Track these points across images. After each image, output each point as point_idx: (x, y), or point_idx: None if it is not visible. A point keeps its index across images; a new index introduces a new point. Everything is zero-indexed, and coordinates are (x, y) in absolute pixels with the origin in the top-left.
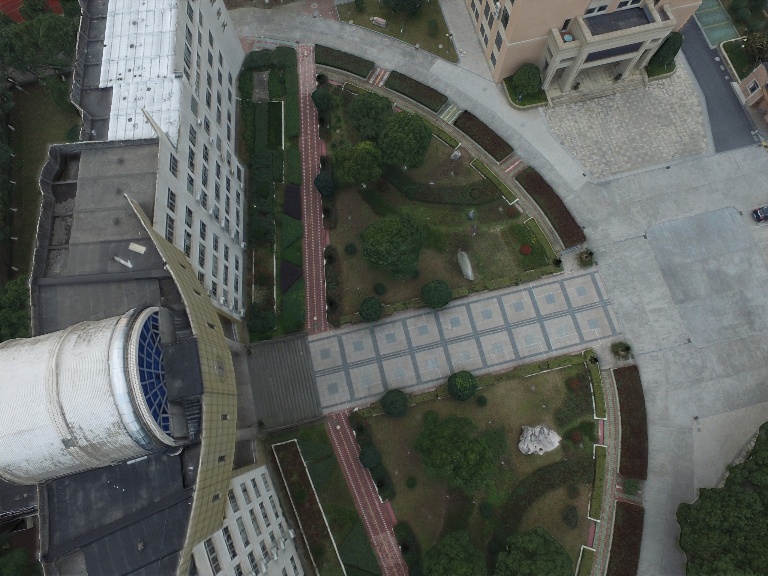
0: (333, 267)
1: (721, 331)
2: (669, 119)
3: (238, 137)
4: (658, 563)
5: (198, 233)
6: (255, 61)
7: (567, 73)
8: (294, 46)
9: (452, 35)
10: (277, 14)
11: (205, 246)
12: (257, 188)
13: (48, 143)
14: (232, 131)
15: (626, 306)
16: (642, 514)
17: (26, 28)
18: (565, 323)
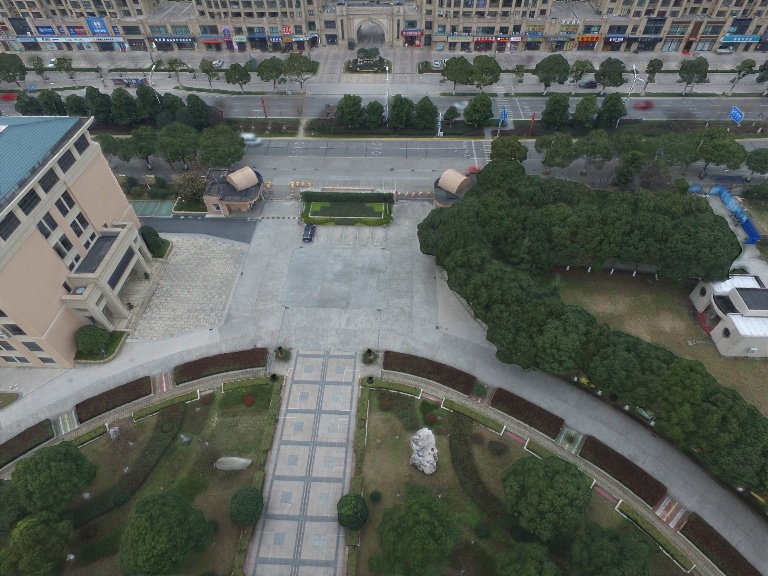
0: None
1: (379, 289)
2: (205, 259)
3: None
4: (542, 394)
5: None
6: None
7: (112, 306)
8: None
9: None
10: None
11: None
12: None
13: None
14: None
15: (336, 341)
16: (503, 390)
17: None
18: (330, 392)
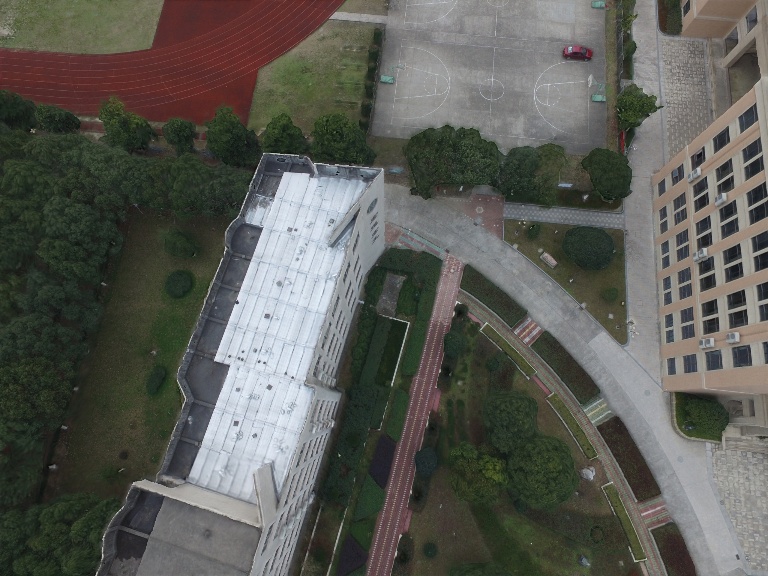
0: (404, 568)
1: None
2: None
3: (346, 350)
4: None
5: (268, 573)
6: (393, 262)
7: (761, 428)
8: (442, 254)
9: (633, 323)
10: (435, 206)
11: (271, 575)
12: (349, 433)
13: (144, 281)
14: (342, 344)
15: None
16: None
17: (161, 173)
18: None
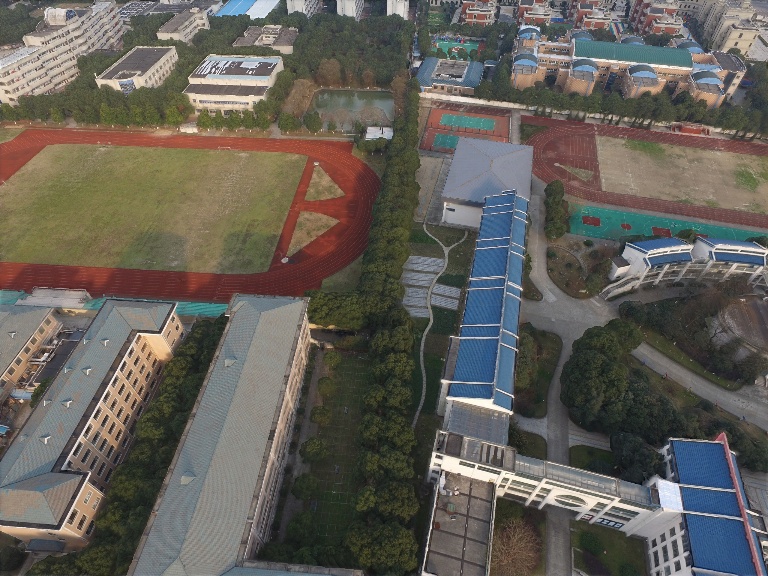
0: None
1: None
2: None
3: None
4: None
5: None
6: None
7: None
8: None
9: None
10: None
11: None
12: None
13: None
14: None
15: None
16: None
17: None
18: None
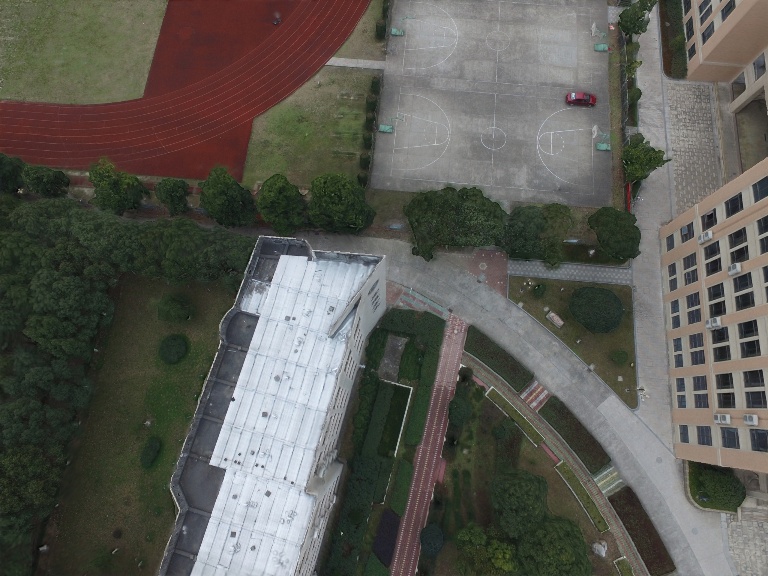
0: None
1: None
2: None
3: (348, 418)
4: None
5: None
6: (395, 324)
7: None
8: (445, 314)
9: (644, 390)
10: (437, 263)
11: None
12: (351, 509)
13: (137, 346)
14: (343, 412)
15: None
16: None
17: (153, 241)
18: None
